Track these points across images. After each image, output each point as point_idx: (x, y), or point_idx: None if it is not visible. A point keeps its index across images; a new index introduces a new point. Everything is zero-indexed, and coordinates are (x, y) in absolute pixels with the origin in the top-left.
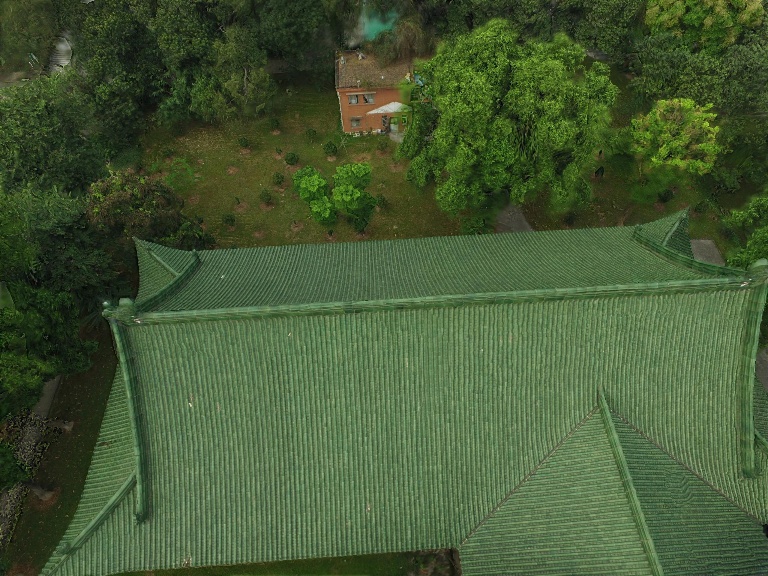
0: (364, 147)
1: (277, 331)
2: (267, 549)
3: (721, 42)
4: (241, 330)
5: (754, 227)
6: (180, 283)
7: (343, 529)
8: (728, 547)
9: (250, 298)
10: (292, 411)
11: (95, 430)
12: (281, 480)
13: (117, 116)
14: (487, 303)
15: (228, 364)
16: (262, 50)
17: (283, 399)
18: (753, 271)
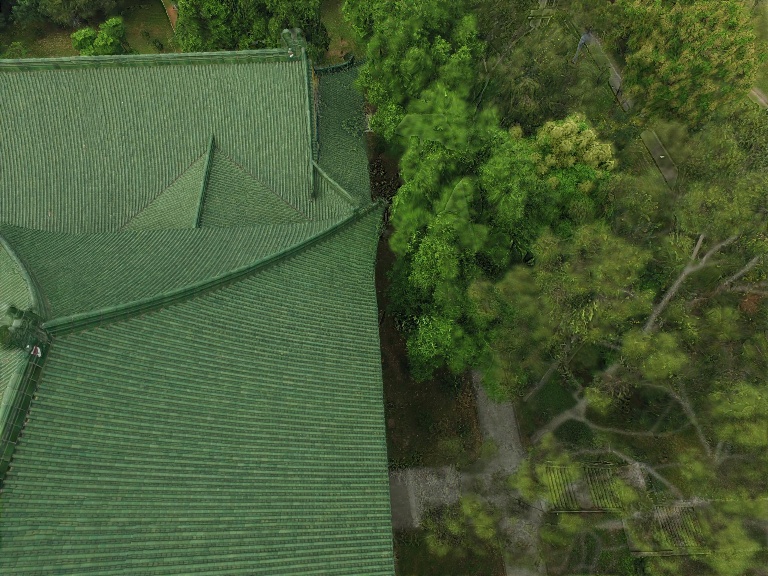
0: None
1: None
2: None
3: None
4: None
5: None
6: None
7: None
8: None
9: None
10: None
11: None
12: None
13: None
14: (118, 66)
15: None
16: None
17: None
18: (286, 40)
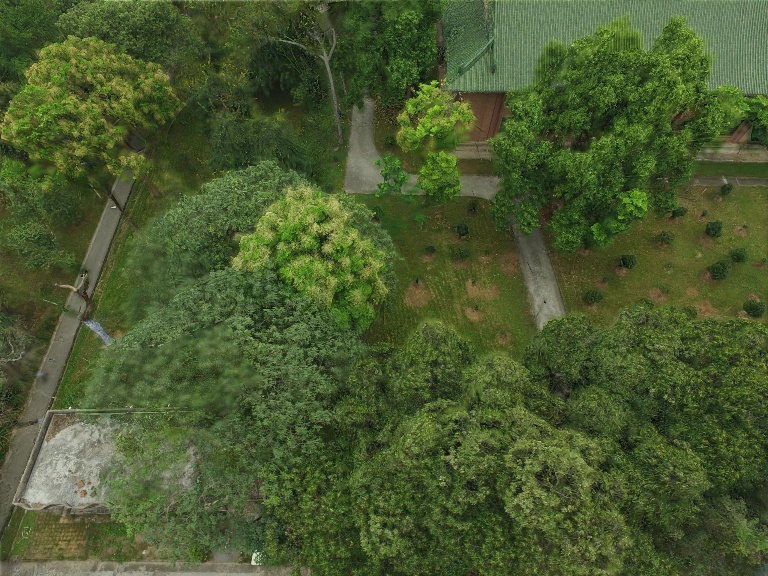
0: None
1: None
2: None
3: None
4: None
5: None
6: None
7: None
8: None
9: (762, 6)
10: None
11: None
12: None
13: None
14: None
15: None
16: None
17: None
18: None
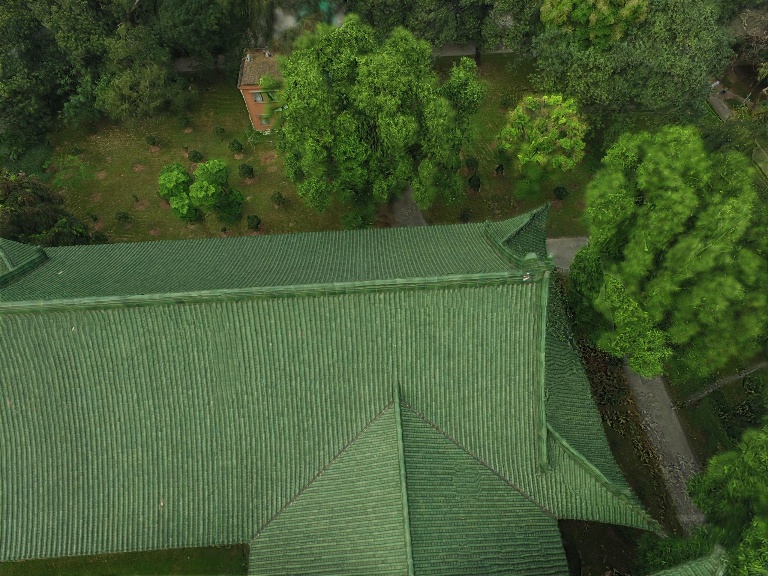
0: (271, 145)
1: (61, 325)
2: (57, 545)
3: (609, 40)
4: (23, 324)
5: (603, 223)
6: (9, 279)
7: (135, 524)
8: (510, 542)
9: (63, 293)
10: (84, 406)
11: None
12: (74, 475)
13: (19, 114)
14: (269, 297)
15: (14, 359)
16: (164, 48)
17: (73, 394)
18: (526, 265)
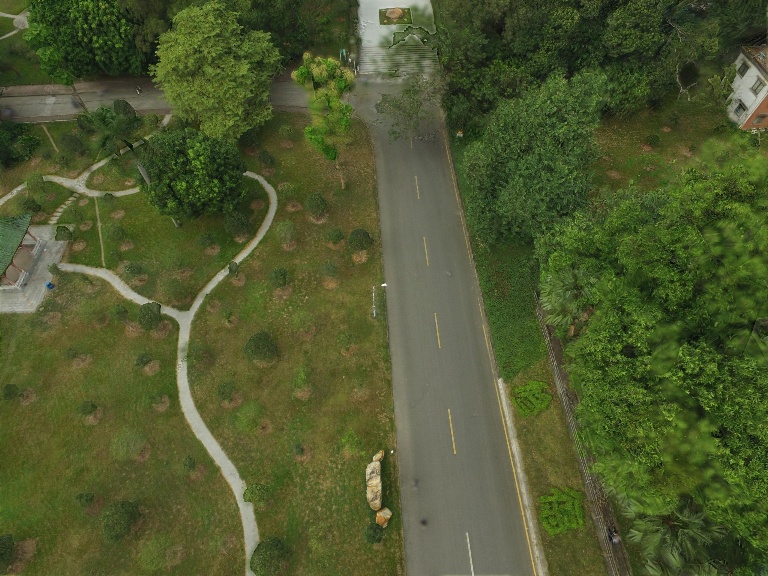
0: None
1: None
2: None
3: None
4: None
5: None
6: None
7: None
8: None
9: None
10: None
11: (697, 431)
12: None
13: None
14: None
15: None
16: None
17: None
18: None
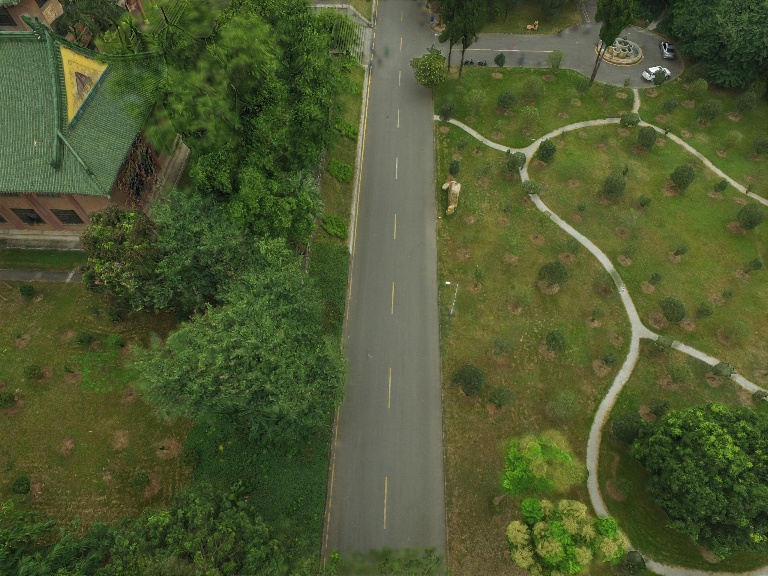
0: None
1: None
2: None
3: None
4: None
5: None
6: None
7: None
8: None
9: (1, 92)
10: None
11: None
12: None
13: None
14: None
15: None
16: None
17: None
18: None
